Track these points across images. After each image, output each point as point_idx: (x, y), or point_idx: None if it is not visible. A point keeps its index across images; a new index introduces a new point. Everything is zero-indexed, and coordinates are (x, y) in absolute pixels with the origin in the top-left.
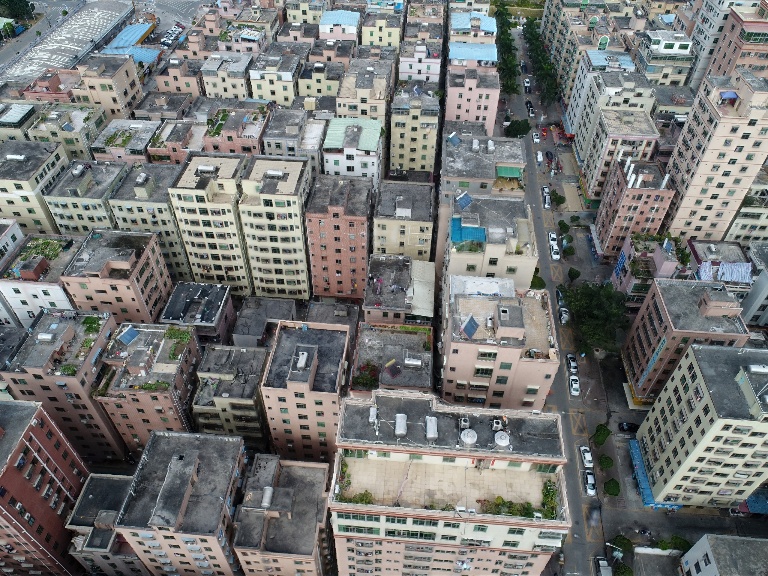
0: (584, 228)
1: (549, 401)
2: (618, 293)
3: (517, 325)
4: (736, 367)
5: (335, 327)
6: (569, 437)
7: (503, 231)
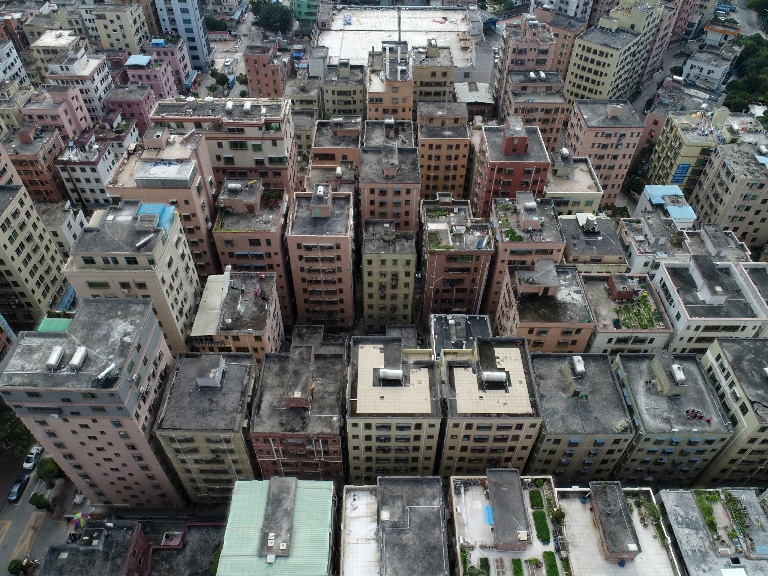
0: None
1: None
2: None
3: (153, 129)
4: None
5: None
6: None
7: (118, 218)
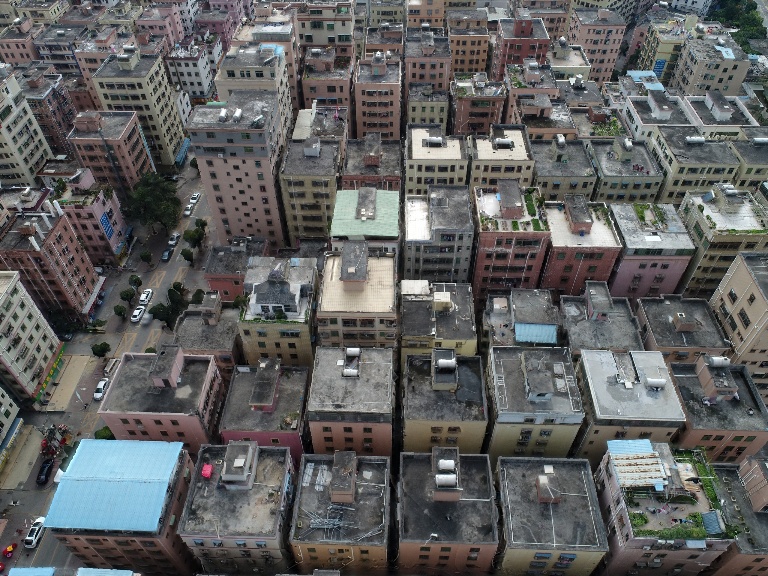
0: (90, 330)
1: None
2: (133, 194)
3: (262, 4)
4: (126, 74)
5: (364, 84)
6: None
7: (246, 51)
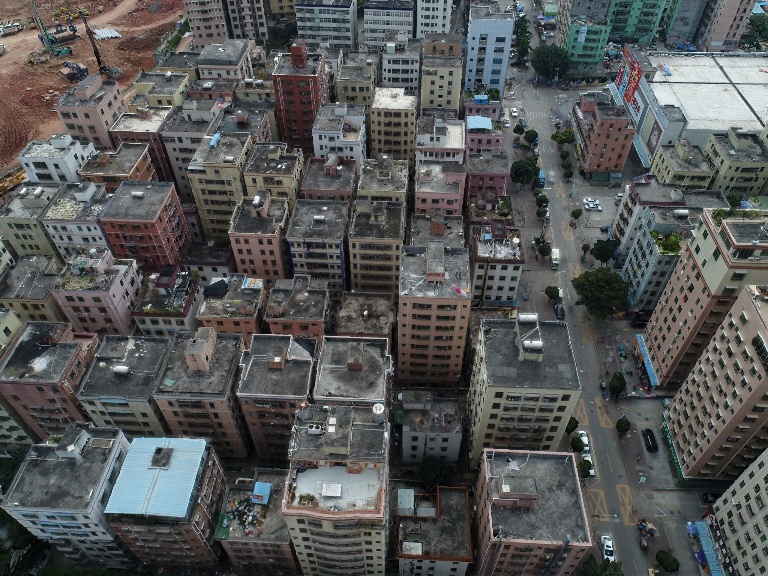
0: None
1: (634, 530)
2: None
3: None
4: (537, 373)
5: None
6: (607, 487)
7: None
